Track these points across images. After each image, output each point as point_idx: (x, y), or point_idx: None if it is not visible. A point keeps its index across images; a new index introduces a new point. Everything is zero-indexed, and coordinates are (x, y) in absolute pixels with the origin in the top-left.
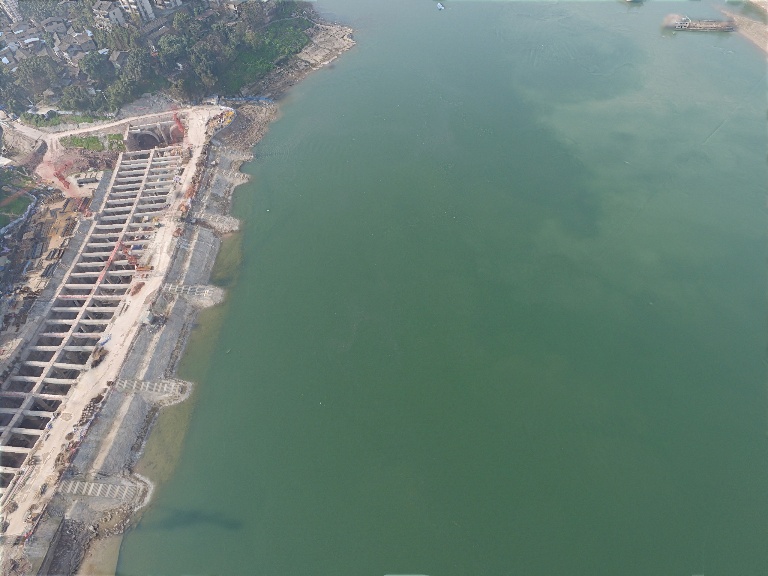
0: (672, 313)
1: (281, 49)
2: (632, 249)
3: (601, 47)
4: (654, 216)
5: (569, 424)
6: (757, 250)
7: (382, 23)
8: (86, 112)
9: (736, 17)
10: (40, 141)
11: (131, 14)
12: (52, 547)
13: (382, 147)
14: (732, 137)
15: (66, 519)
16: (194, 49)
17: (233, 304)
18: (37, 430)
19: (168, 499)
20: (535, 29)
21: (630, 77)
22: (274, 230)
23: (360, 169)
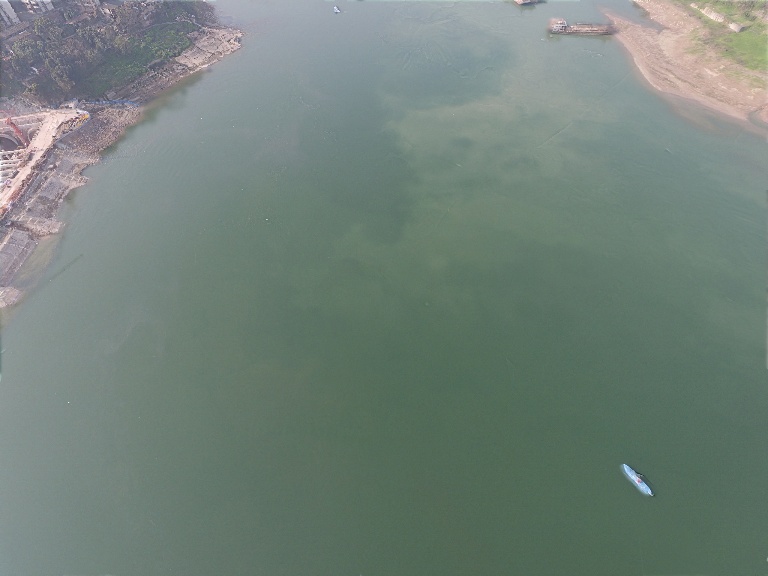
0: (444, 313)
1: (158, 53)
2: (424, 251)
3: (474, 50)
4: (460, 218)
5: (299, 422)
6: (550, 251)
7: (275, 26)
8: None
9: (616, 20)
10: None
11: None
12: None
13: (226, 150)
14: (570, 140)
15: None
16: (48, 54)
17: (26, 305)
18: None
19: None
20: (417, 32)
21: (490, 80)
22: (91, 232)
23: (197, 172)
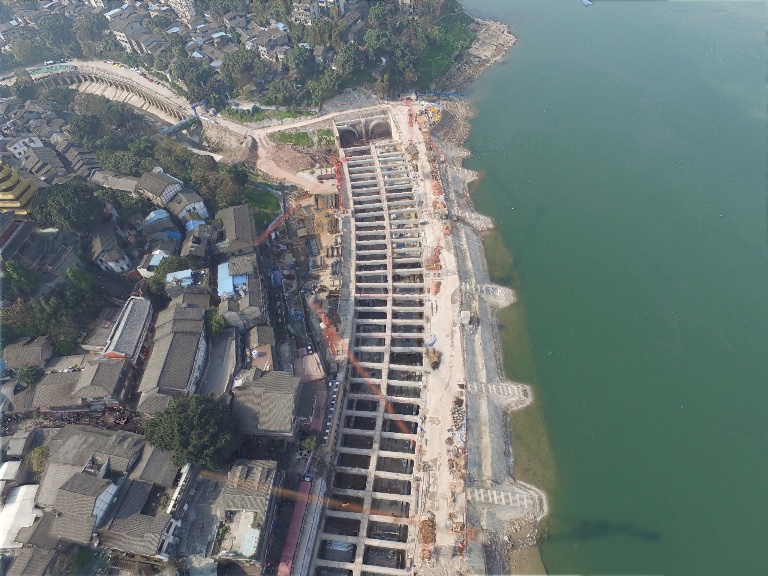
0: None
1: (454, 44)
2: None
3: None
4: None
5: None
6: None
7: (533, 19)
8: (291, 107)
9: None
10: (249, 137)
11: (331, 8)
12: (485, 558)
13: (602, 144)
14: None
15: (484, 529)
16: (399, 43)
17: (527, 304)
18: (409, 434)
19: (567, 508)
20: (703, 24)
21: None
22: (533, 228)
23: (591, 166)
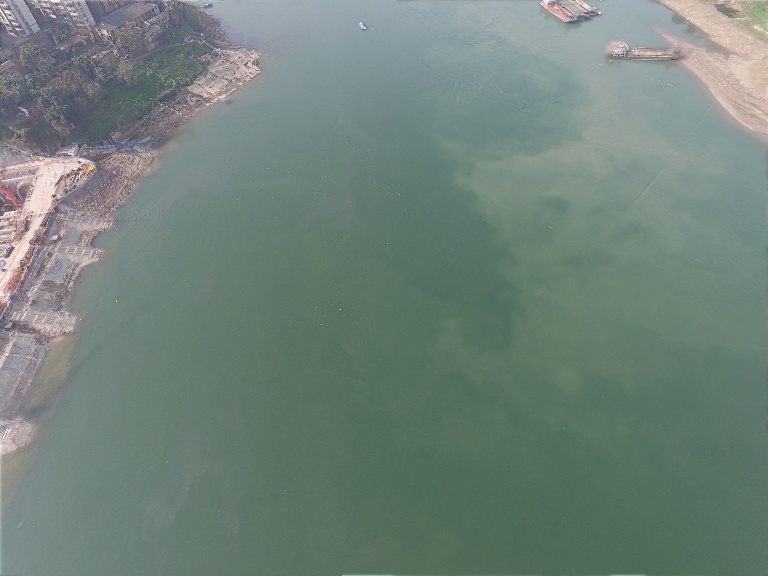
0: (588, 442)
1: (167, 81)
2: (545, 353)
3: (531, 79)
4: (575, 303)
5: None
6: (690, 346)
7: (295, 46)
8: None
9: (677, 43)
10: None
11: None
12: None
13: (269, 210)
14: (668, 192)
15: None
16: (40, 91)
17: (43, 446)
18: None
19: None
20: (462, 56)
21: (560, 117)
22: (117, 331)
23: (239, 240)
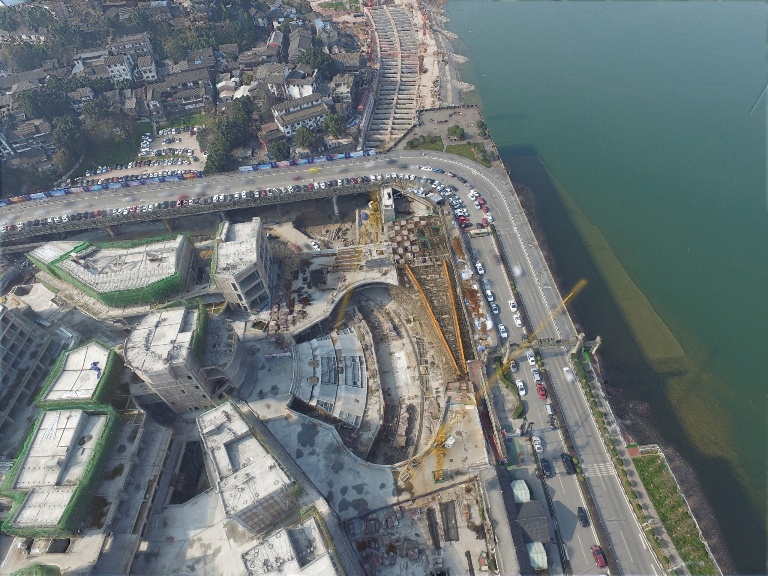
0: (726, 56)
1: None
2: None
3: None
4: (709, 22)
5: (680, 86)
6: None
7: None
8: None
9: None
10: None
11: None
12: None
13: (527, 4)
14: None
15: None
16: None
17: (475, 62)
18: None
19: (487, 114)
20: None
21: None
22: (481, 37)
23: (518, 13)
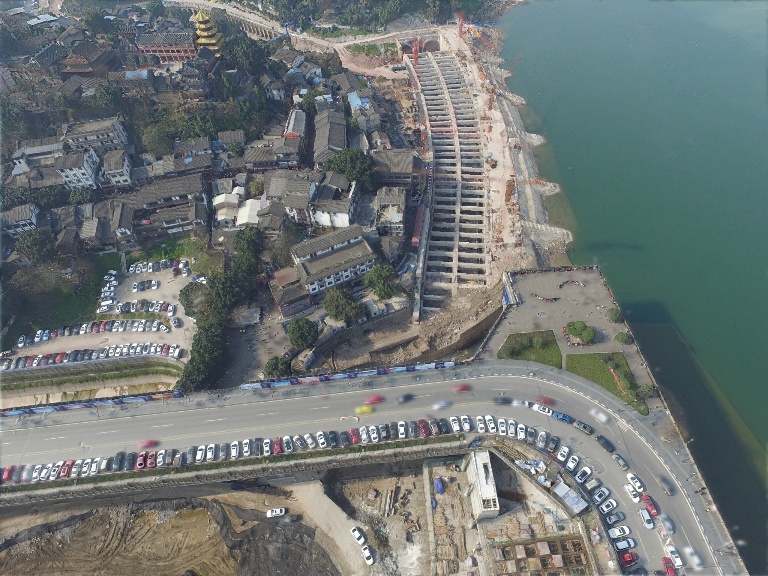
0: None
1: None
2: None
3: None
4: None
5: None
6: None
7: None
8: (363, 26)
9: None
10: (331, 48)
11: None
12: None
13: (607, 54)
14: None
15: (533, 240)
16: None
17: (553, 144)
18: None
19: (585, 238)
20: None
21: None
22: (555, 103)
23: (598, 67)
